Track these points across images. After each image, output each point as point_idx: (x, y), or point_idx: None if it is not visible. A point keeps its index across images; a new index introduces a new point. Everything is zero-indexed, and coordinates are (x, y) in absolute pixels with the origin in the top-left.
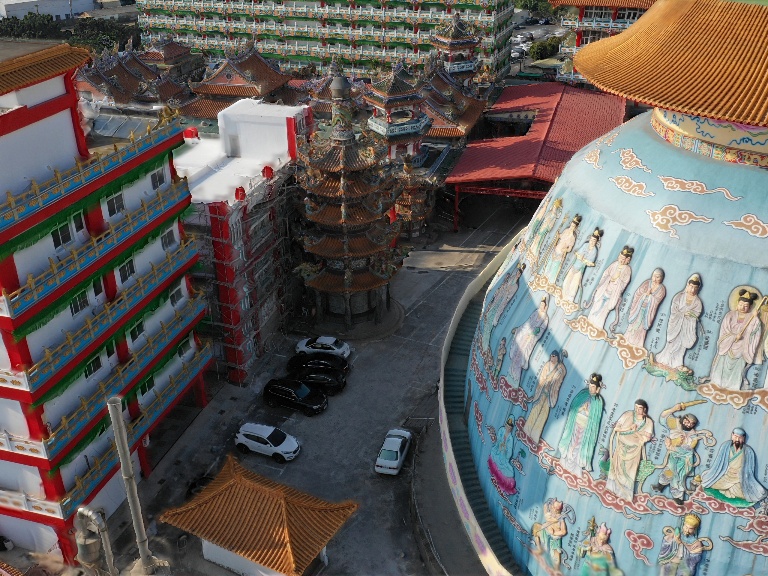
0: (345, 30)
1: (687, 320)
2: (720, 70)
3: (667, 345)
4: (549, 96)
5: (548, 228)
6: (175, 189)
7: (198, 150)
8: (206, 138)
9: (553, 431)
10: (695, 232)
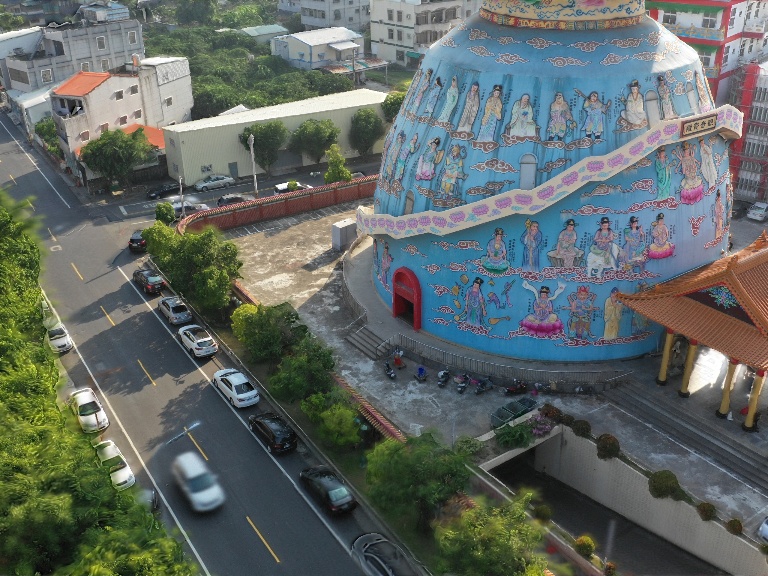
0: None
1: None
2: None
3: None
4: None
5: None
6: (707, 31)
7: None
8: None
9: None
10: None
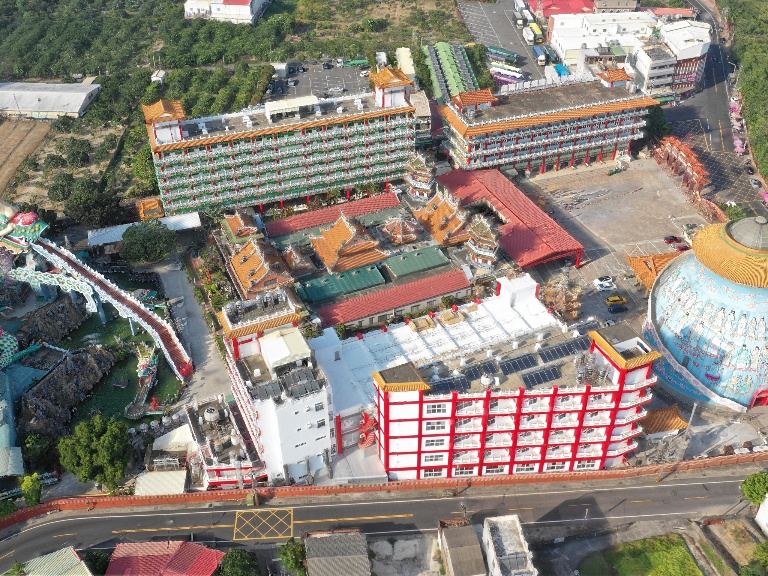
0: (324, 167)
1: (763, 327)
2: (762, 274)
3: (760, 333)
4: (474, 184)
5: (711, 312)
6: None
7: (491, 308)
8: (488, 301)
9: (734, 361)
10: (759, 307)
